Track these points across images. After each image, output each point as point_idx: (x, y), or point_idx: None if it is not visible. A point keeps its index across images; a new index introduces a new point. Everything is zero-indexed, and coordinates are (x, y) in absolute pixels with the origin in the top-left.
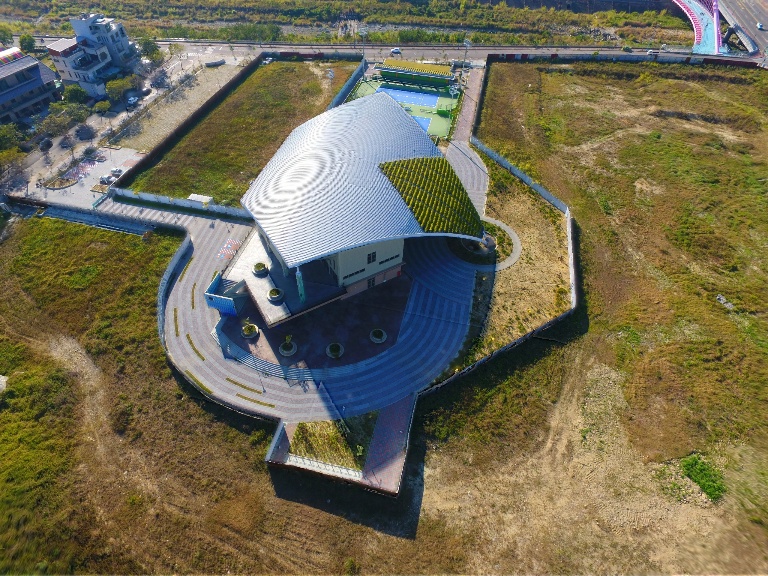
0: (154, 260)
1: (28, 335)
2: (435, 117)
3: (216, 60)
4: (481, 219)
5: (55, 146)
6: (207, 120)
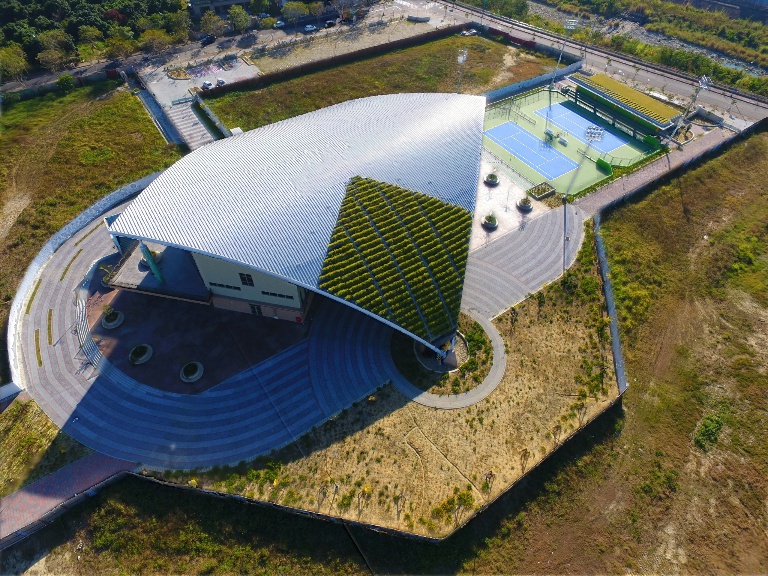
0: (146, 170)
1: (17, 180)
2: (588, 166)
3: (420, 16)
4: (480, 322)
5: (214, 44)
6: (344, 68)
